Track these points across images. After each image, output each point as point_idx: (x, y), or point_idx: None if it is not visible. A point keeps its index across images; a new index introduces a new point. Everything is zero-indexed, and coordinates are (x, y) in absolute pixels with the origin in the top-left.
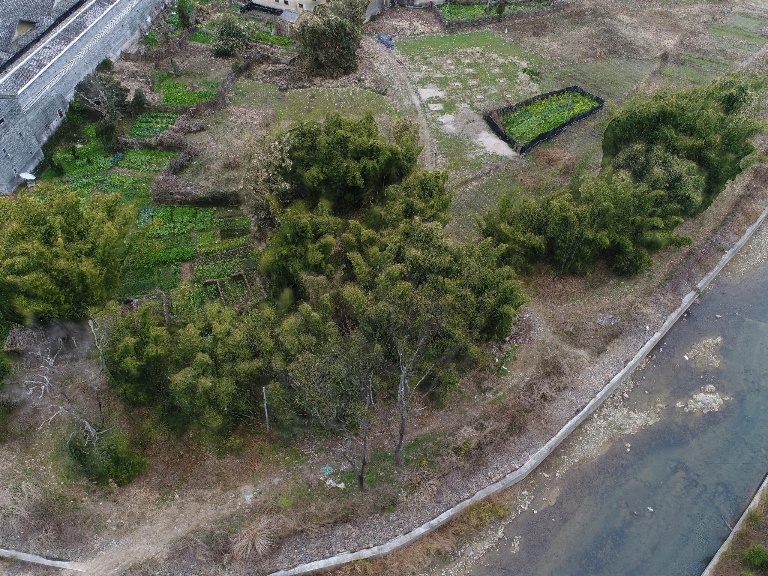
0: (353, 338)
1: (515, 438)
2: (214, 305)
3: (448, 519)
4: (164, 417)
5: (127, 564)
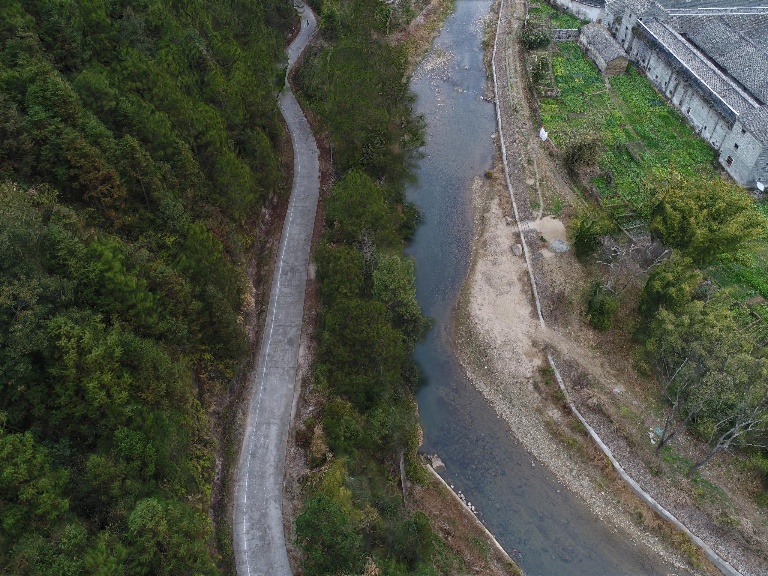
0: (766, 406)
1: (766, 566)
2: (729, 312)
3: (667, 518)
4: (640, 327)
5: (554, 344)
